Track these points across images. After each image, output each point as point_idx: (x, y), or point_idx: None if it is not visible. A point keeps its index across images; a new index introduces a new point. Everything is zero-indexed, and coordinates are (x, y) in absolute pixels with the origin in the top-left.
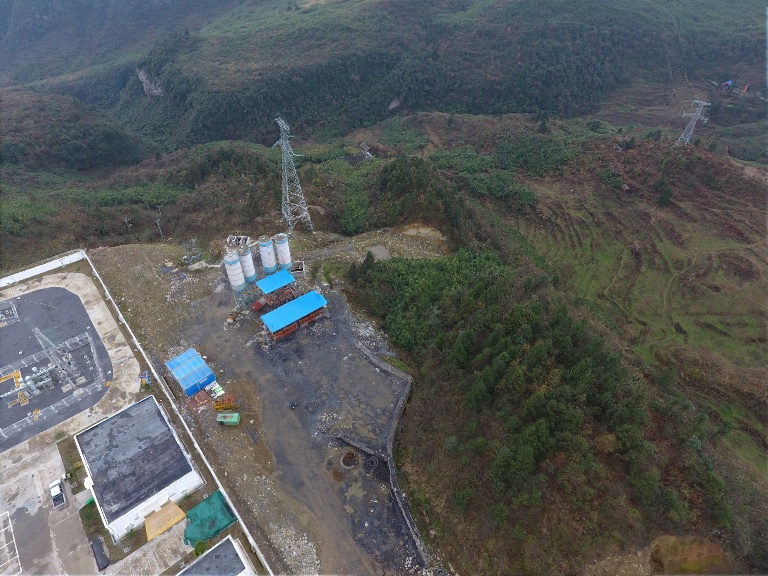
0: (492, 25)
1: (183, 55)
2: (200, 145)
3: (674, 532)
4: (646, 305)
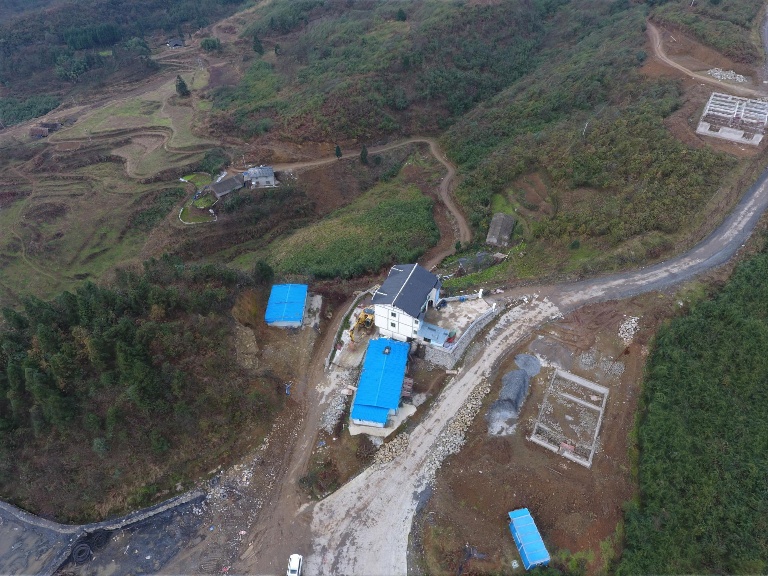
0: None
1: None
2: None
3: (231, 305)
4: (40, 289)
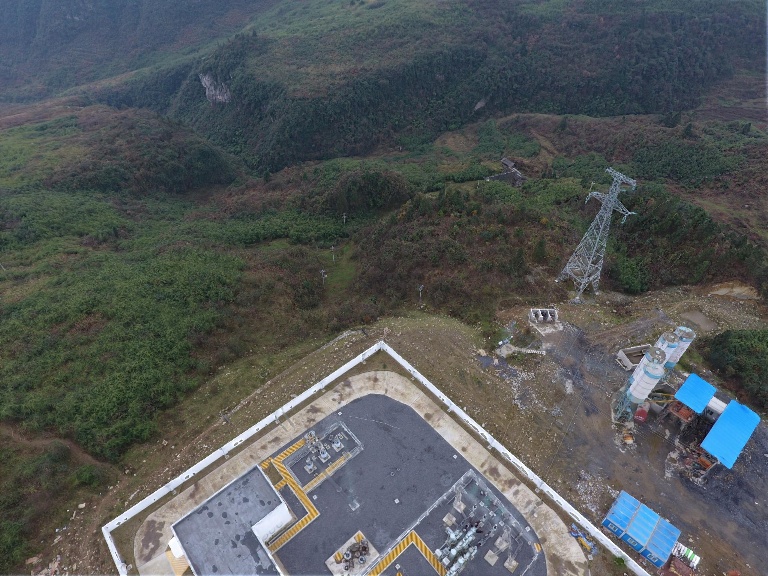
0: (582, 16)
1: (253, 58)
2: (311, 162)
3: None
4: None
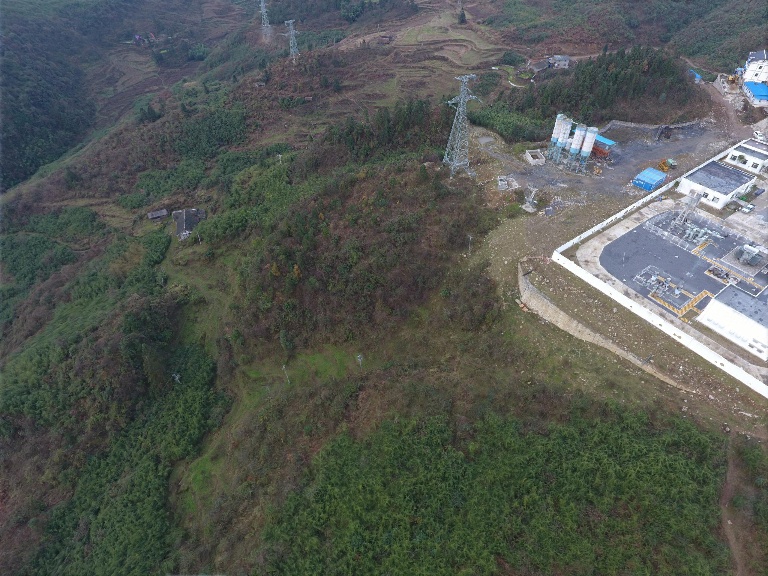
0: None
1: None
2: None
3: None
4: None
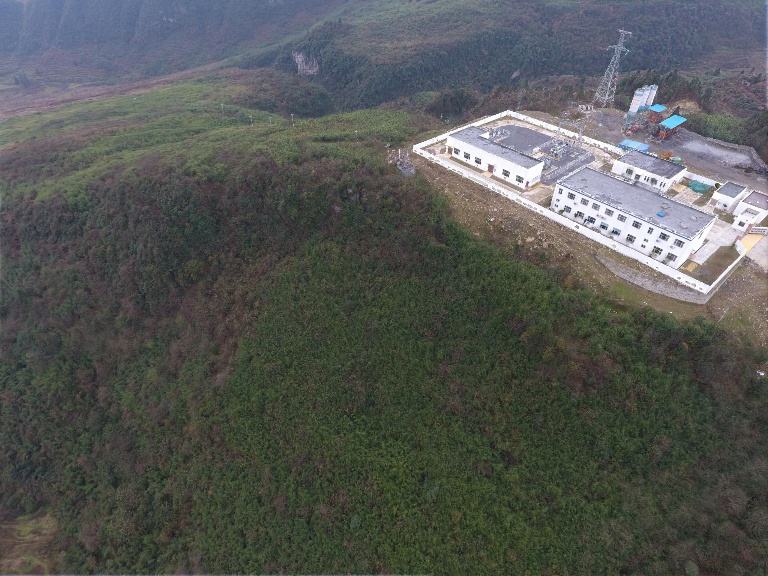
0: (596, 6)
1: (339, 39)
2: (404, 98)
3: None
4: None
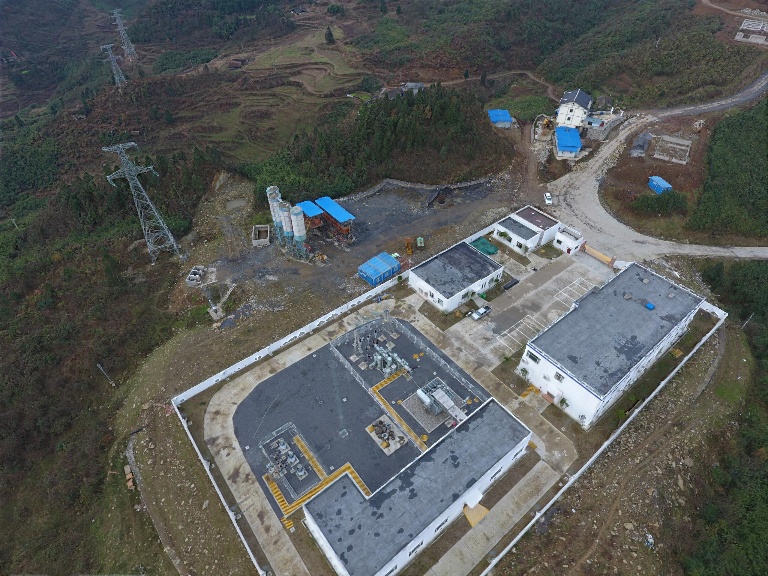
0: None
1: None
2: None
3: None
4: None
